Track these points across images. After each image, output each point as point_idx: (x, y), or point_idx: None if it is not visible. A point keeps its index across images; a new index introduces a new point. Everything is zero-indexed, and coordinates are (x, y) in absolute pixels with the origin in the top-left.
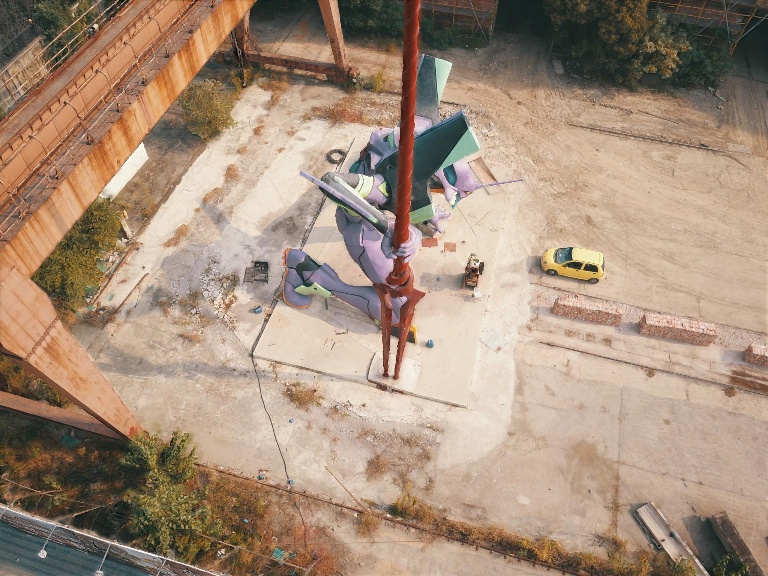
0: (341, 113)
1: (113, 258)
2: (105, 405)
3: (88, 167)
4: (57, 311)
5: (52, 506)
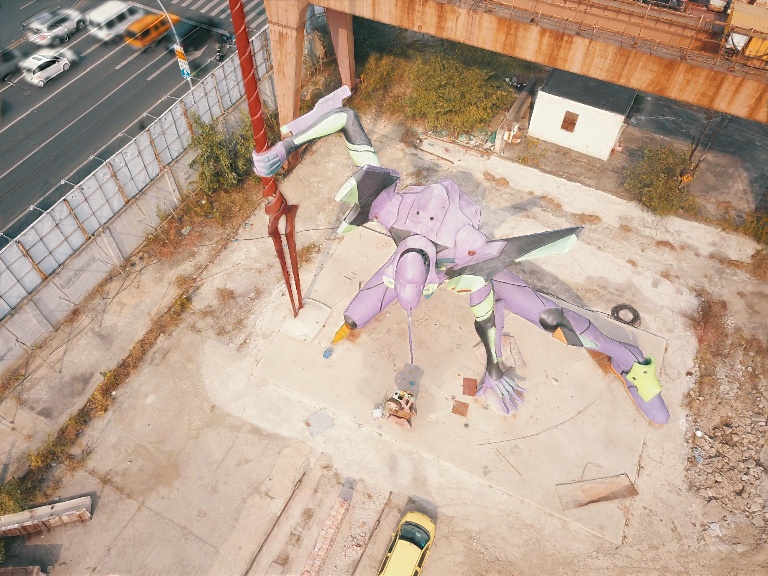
0: (720, 332)
1: (473, 143)
2: (284, 104)
3: (394, 0)
4: None
5: None
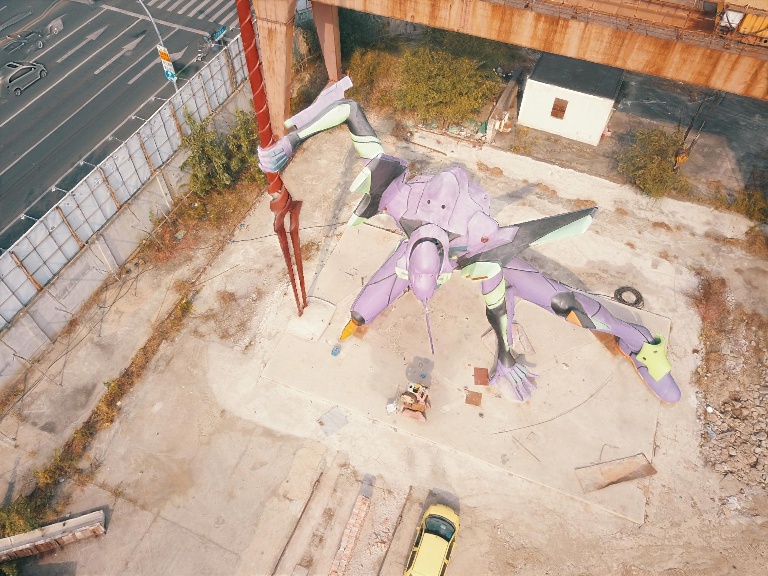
0: (722, 309)
1: (464, 134)
2: (275, 101)
3: None
4: (407, 109)
5: (243, 115)
